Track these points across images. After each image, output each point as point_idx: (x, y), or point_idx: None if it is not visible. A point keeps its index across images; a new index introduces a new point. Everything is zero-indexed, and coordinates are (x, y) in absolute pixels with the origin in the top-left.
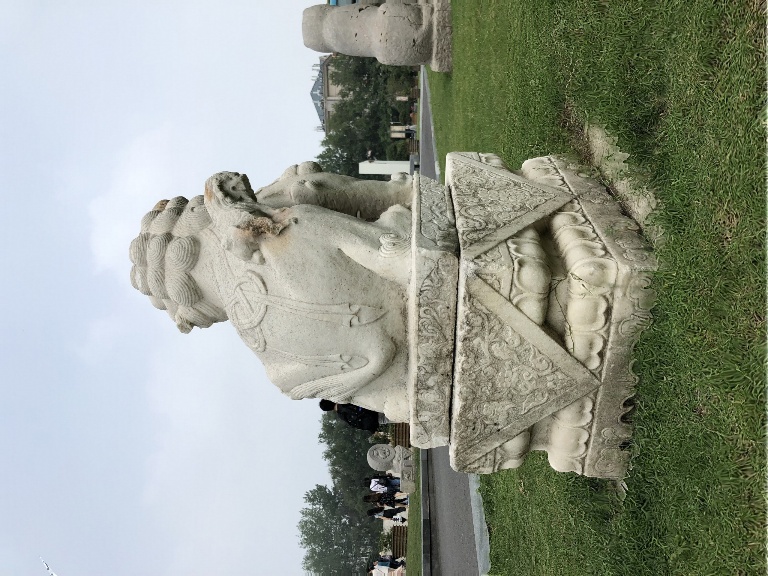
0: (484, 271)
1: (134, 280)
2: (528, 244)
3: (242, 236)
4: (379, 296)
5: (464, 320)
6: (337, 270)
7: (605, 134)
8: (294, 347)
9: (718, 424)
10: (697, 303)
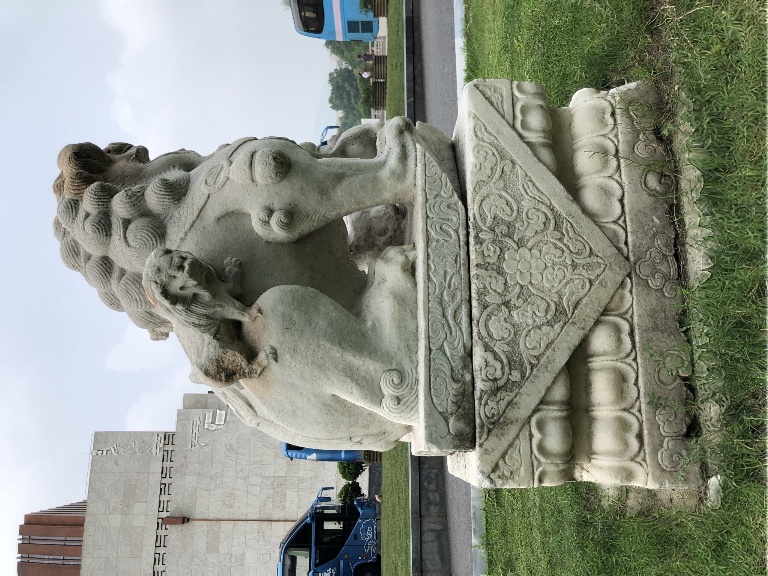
0: None
1: None
2: (555, 428)
3: None
4: (382, 426)
5: None
6: (334, 416)
7: None
8: None
9: None
10: None
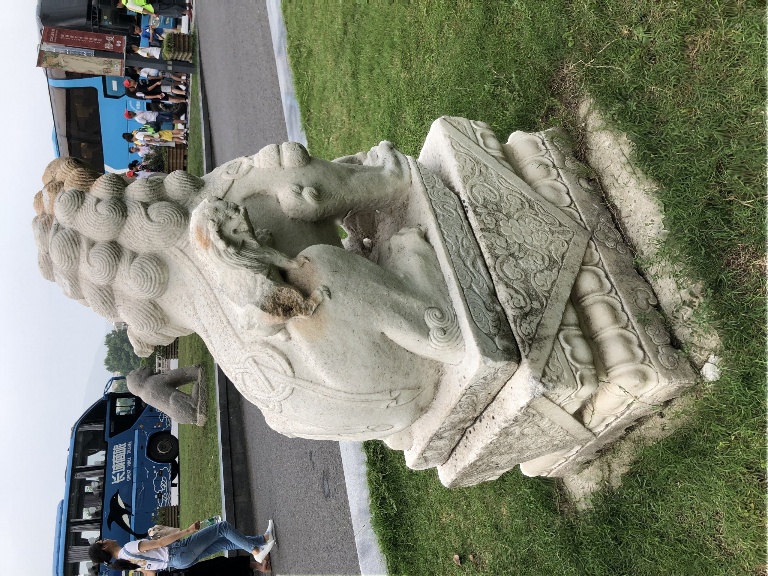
0: (551, 392)
1: (49, 274)
2: (578, 342)
3: (270, 321)
4: (418, 377)
5: (512, 418)
6: (381, 358)
7: (619, 149)
8: (319, 422)
9: (744, 573)
10: (763, 495)
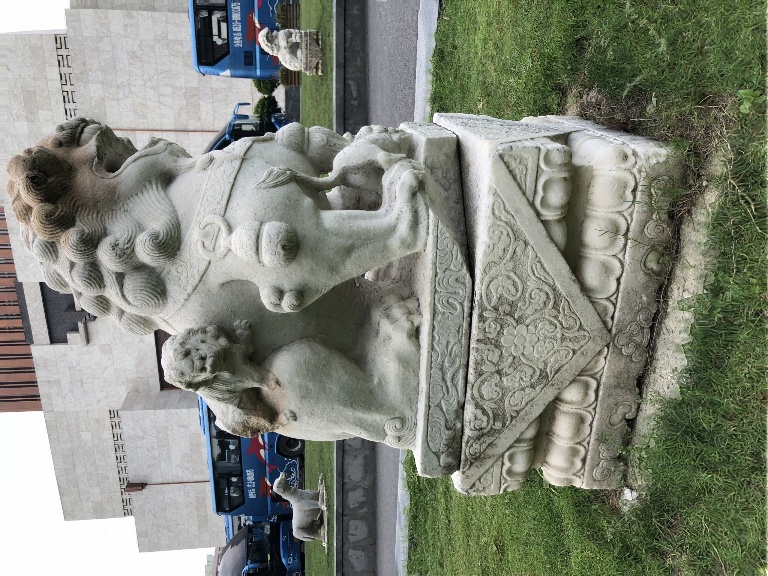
0: None
1: None
2: (521, 459)
3: None
4: None
5: None
6: None
7: (705, 273)
8: None
9: None
10: None
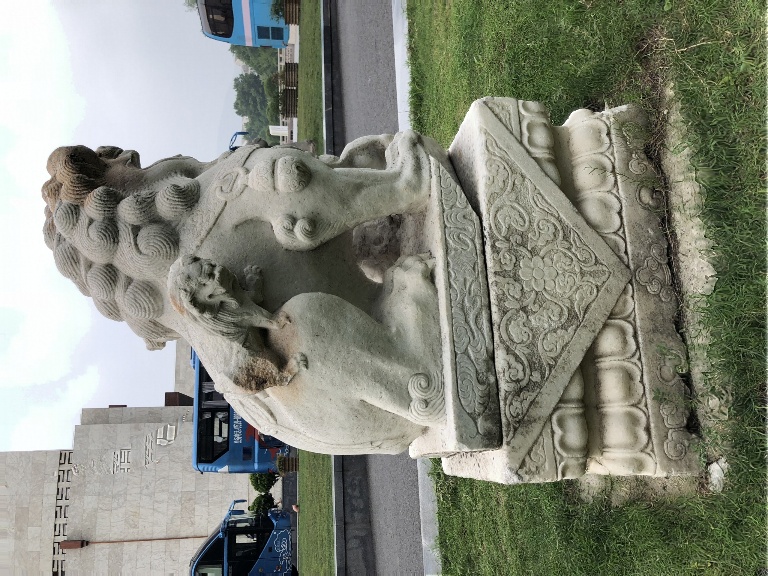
0: None
1: None
2: (573, 425)
3: None
4: (402, 430)
5: None
6: (360, 421)
7: None
8: None
9: None
10: None
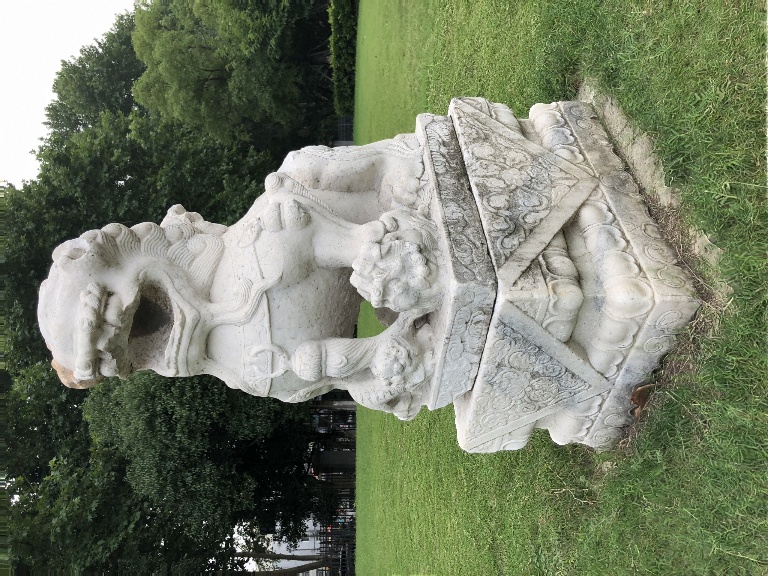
0: None
1: None
2: None
3: None
4: None
5: None
6: None
7: None
8: None
9: None
10: None
